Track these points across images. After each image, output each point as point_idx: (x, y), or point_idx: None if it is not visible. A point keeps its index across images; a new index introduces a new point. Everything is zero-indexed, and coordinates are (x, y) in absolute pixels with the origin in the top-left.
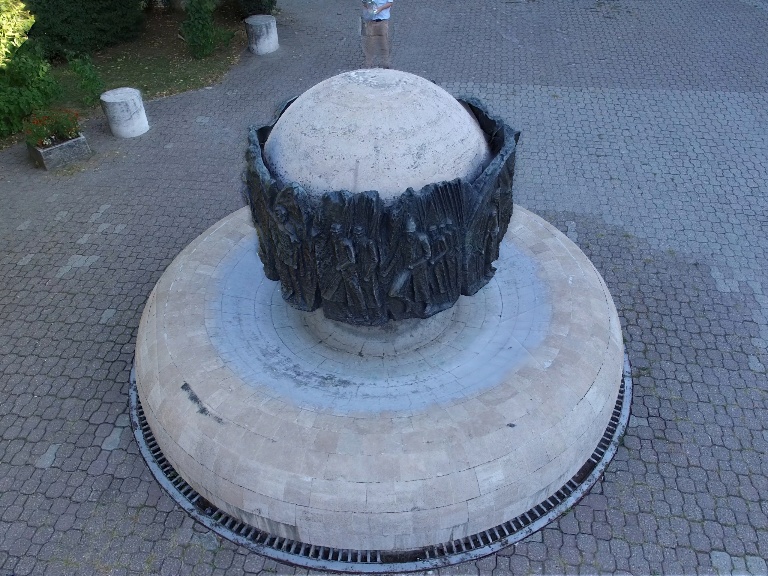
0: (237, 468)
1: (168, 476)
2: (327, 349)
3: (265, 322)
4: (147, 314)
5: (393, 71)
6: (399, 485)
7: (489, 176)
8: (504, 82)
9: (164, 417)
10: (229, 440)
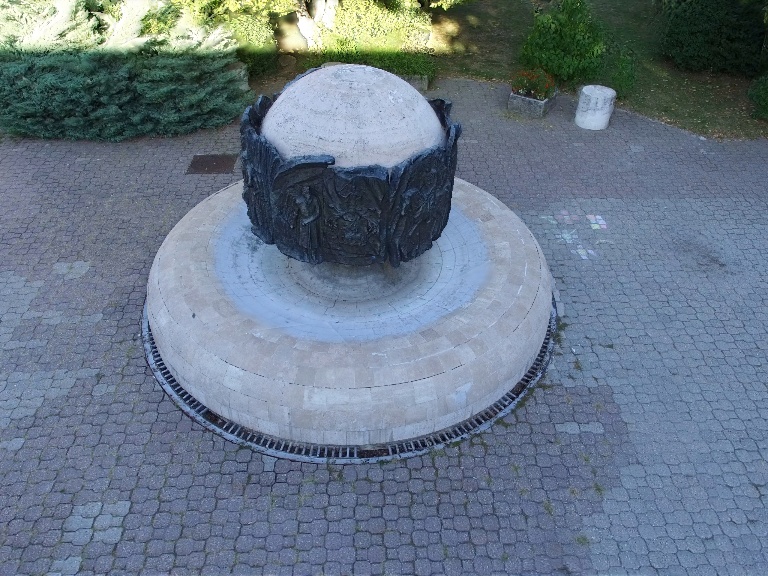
0: None
1: None
2: None
3: None
4: None
5: (372, 78)
6: None
7: (288, 162)
8: None
9: None
10: None
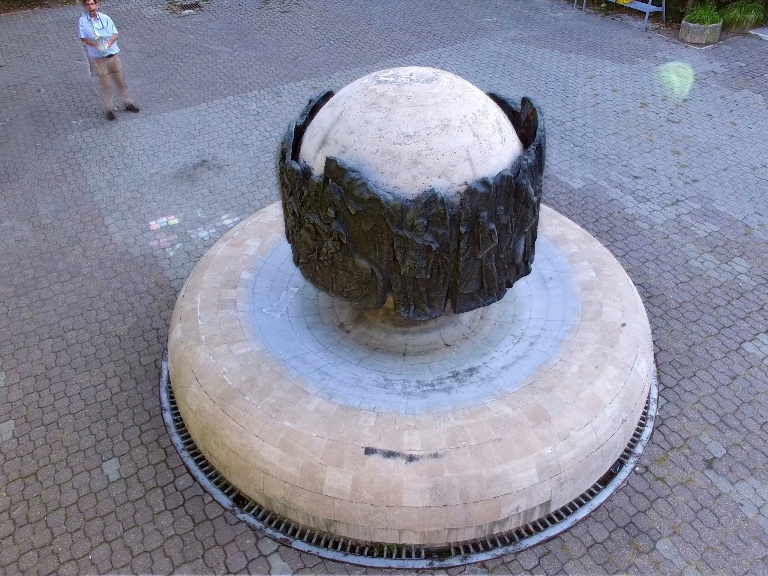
0: (486, 483)
1: (375, 556)
2: (417, 357)
3: (344, 364)
4: (229, 421)
5: None
6: (608, 410)
7: None
8: (259, 88)
9: (367, 493)
10: (461, 465)
